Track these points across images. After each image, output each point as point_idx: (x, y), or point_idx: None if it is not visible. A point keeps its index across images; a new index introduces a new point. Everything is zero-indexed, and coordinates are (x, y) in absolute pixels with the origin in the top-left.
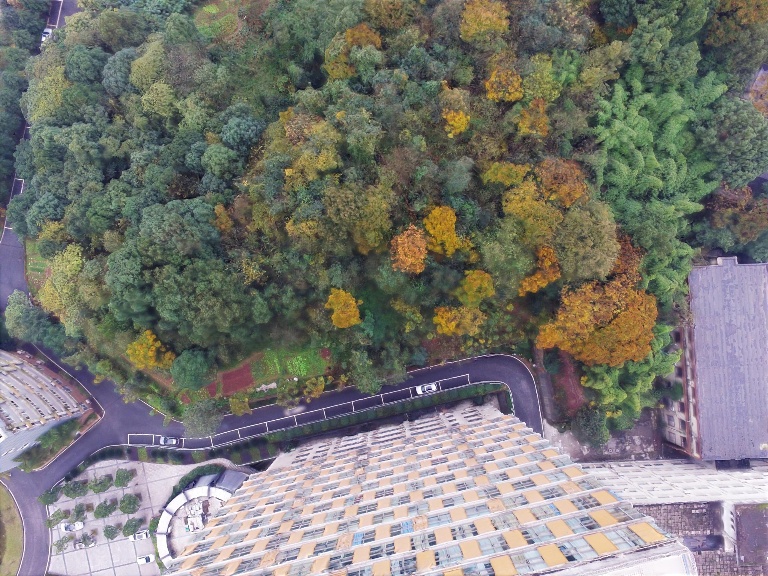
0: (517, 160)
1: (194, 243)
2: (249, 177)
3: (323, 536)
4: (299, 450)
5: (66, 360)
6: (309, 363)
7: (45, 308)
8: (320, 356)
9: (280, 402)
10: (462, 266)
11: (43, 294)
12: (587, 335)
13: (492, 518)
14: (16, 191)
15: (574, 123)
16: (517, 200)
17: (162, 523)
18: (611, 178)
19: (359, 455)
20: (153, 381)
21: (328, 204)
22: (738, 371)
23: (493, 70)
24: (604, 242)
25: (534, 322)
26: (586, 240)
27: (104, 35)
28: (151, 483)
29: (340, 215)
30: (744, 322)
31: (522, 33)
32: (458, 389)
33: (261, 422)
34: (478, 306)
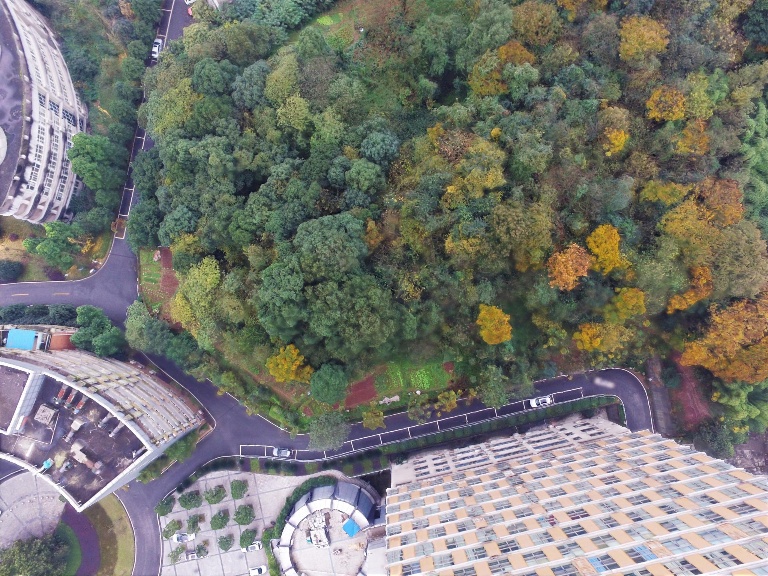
0: (678, 179)
1: (353, 259)
2: (403, 193)
3: (553, 560)
4: (412, 462)
5: (192, 372)
6: (432, 376)
7: (174, 320)
8: (443, 369)
9: (412, 416)
10: (608, 283)
11: (175, 306)
12: (734, 353)
13: (742, 545)
14: (126, 201)
15: (728, 142)
16: (679, 219)
17: (285, 535)
18: (750, 195)
19: (502, 471)
20: (274, 393)
21: (496, 222)
22: None
23: (637, 87)
24: (758, 261)
25: (667, 338)
26: (742, 259)
27: (233, 48)
28: (262, 494)
29: (511, 234)
30: None
31: (681, 52)
32: (572, 402)
33: (374, 434)
34: (622, 323)
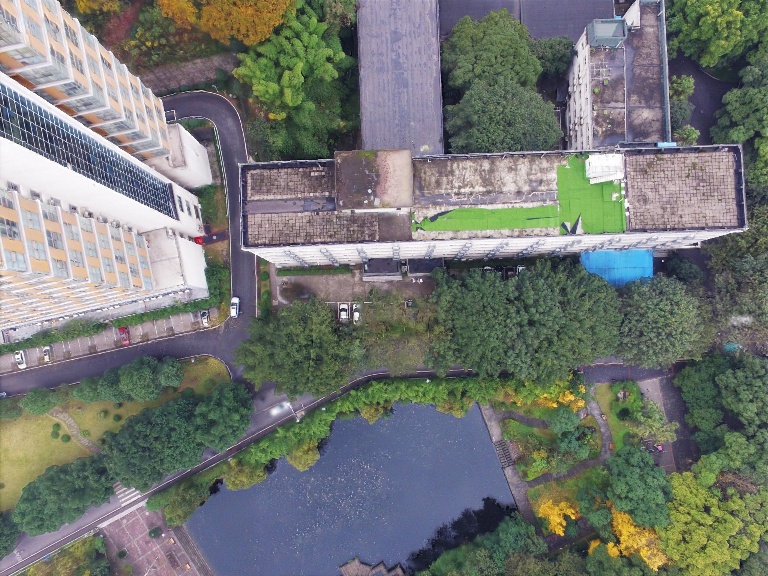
0: None
1: None
2: None
3: None
4: None
5: None
6: None
7: None
8: None
9: None
10: None
11: None
12: None
13: None
14: None
15: None
16: None
17: None
18: None
19: None
20: None
21: None
22: (402, 76)
23: None
24: None
25: None
26: None
27: None
28: None
29: None
30: (409, 30)
31: None
32: None
33: None
34: None
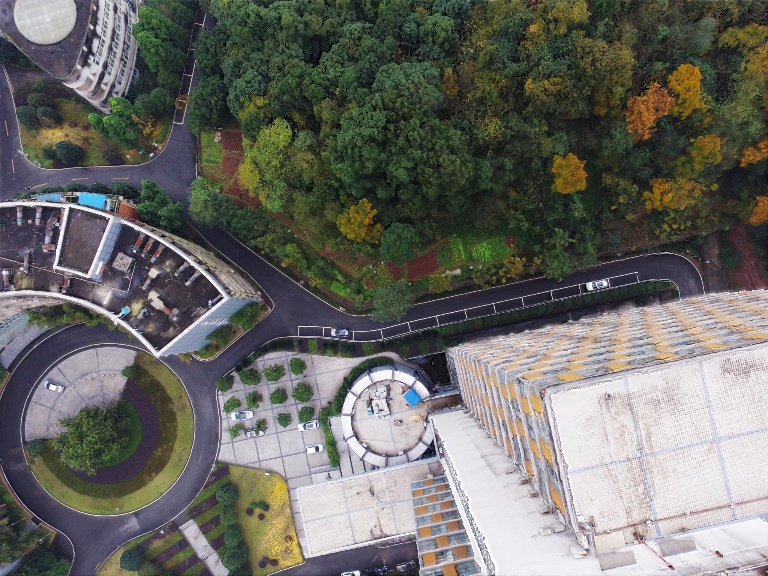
0: (760, 20)
1: (434, 100)
2: None
3: None
4: None
5: (257, 241)
6: (494, 250)
7: (242, 187)
8: (505, 244)
9: (477, 281)
10: None
11: (243, 171)
12: None
13: None
14: (185, 87)
15: None
16: (760, 59)
17: (347, 405)
18: None
19: (572, 324)
20: (336, 267)
21: (580, 56)
22: None
23: None
24: None
25: (733, 205)
26: None
27: None
28: (319, 375)
29: (596, 65)
30: None
31: None
32: (628, 286)
33: (431, 316)
34: None
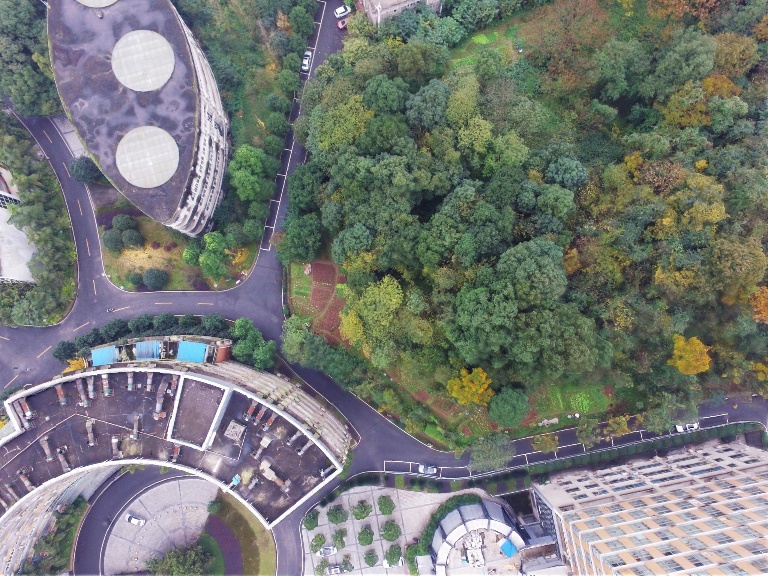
0: None
1: None
2: None
3: None
4: (556, 483)
5: (356, 389)
6: (592, 400)
7: (344, 337)
8: (603, 393)
9: (582, 440)
10: None
11: (348, 324)
12: None
13: None
14: (273, 213)
15: None
16: None
17: (442, 554)
18: None
19: (686, 499)
20: (431, 411)
21: (717, 256)
22: None
23: None
24: None
25: None
26: None
27: (407, 66)
28: (405, 510)
29: (735, 269)
30: None
31: None
32: (718, 428)
33: (520, 454)
34: None
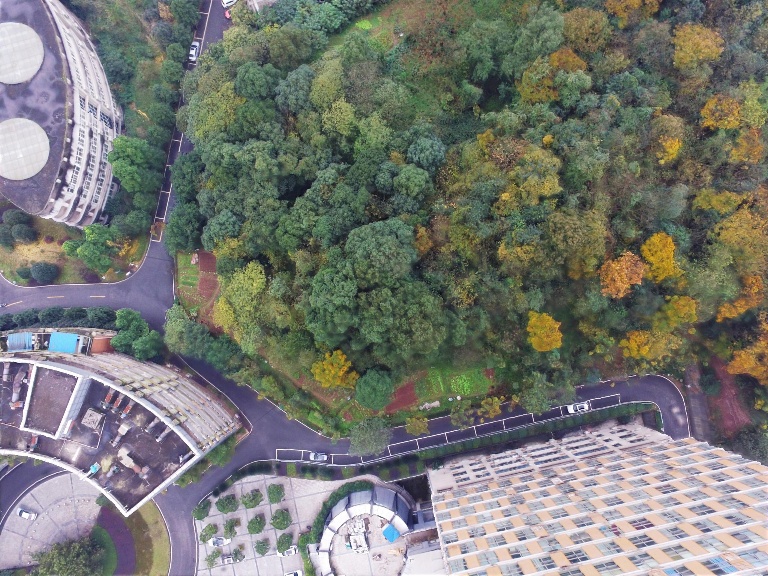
0: (732, 188)
1: (406, 266)
2: (454, 200)
3: (629, 572)
4: (449, 467)
5: (233, 376)
6: (473, 382)
7: (217, 324)
8: (484, 375)
9: (455, 422)
10: (657, 290)
11: (218, 311)
12: None
13: None
14: (163, 204)
15: None
16: (733, 228)
17: (325, 541)
18: None
19: (549, 478)
20: (314, 398)
21: (552, 230)
22: None
23: (686, 95)
24: None
25: (712, 345)
26: None
27: (276, 52)
28: (298, 498)
29: (568, 241)
30: None
31: (735, 61)
32: (609, 409)
33: (411, 439)
34: None
